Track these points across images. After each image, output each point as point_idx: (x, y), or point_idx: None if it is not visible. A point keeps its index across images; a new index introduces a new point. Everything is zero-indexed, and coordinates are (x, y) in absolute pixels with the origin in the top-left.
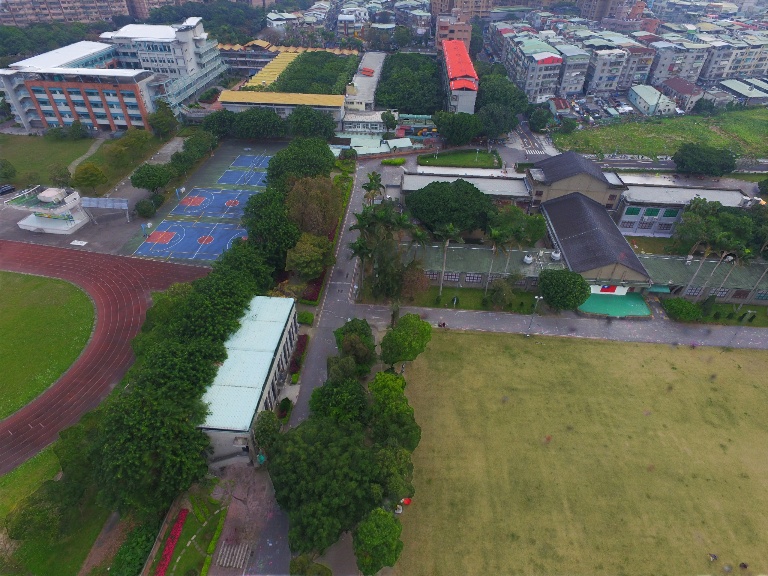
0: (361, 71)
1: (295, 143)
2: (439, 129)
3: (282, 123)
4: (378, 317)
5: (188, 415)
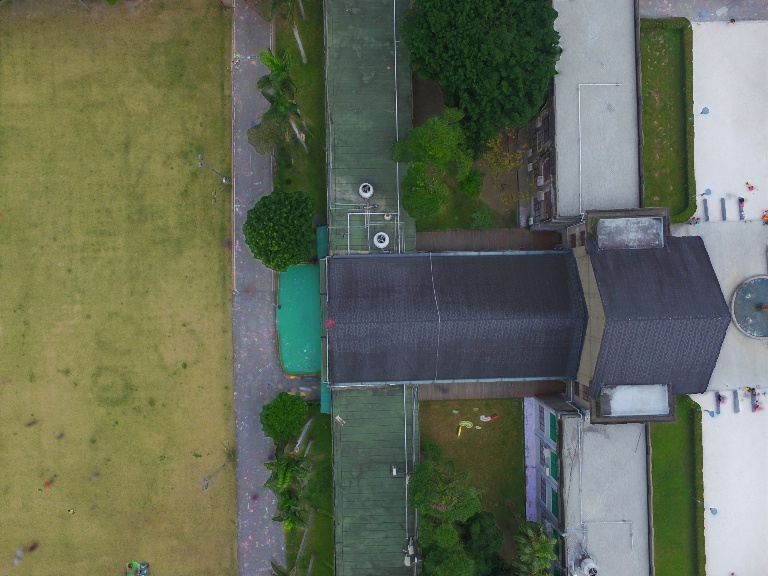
0: None
1: None
2: None
3: None
4: None
5: None
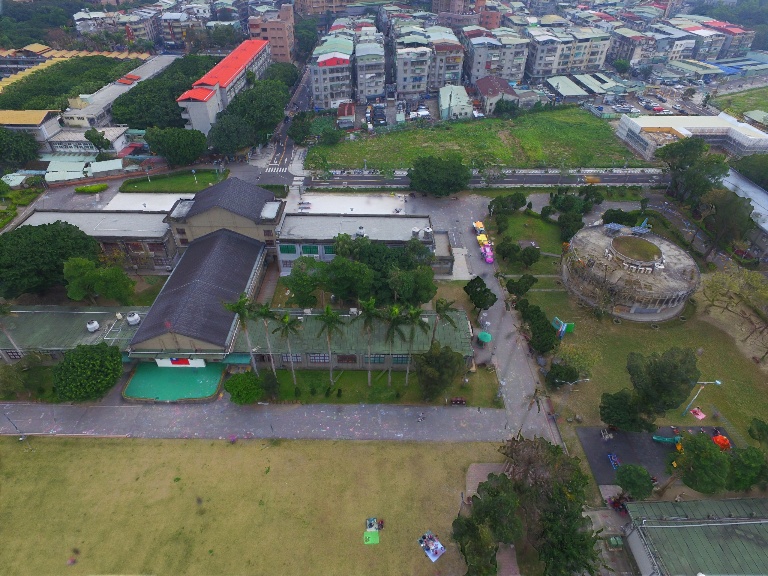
0: (124, 78)
1: None
2: (150, 148)
3: None
4: None
5: None
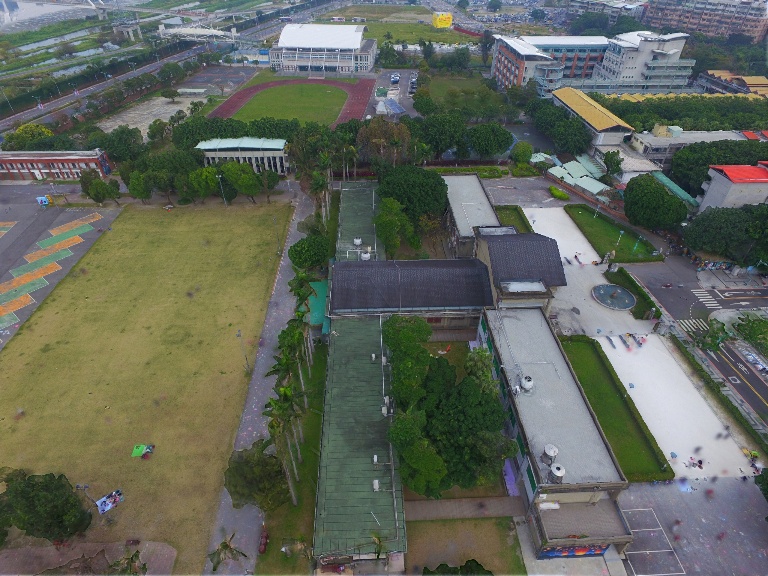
0: None
1: None
2: None
3: None
4: (304, 198)
5: (202, 134)
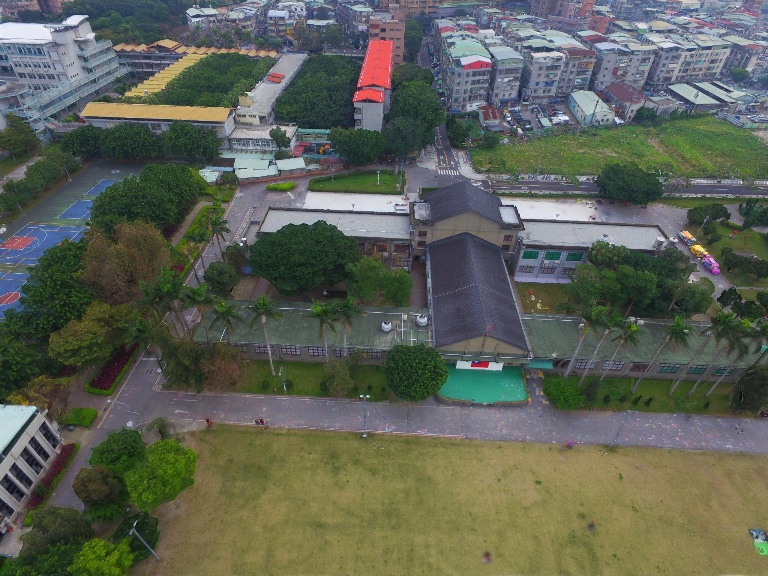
0: (269, 76)
1: (147, 171)
2: (335, 148)
3: (155, 141)
4: (183, 411)
5: None
